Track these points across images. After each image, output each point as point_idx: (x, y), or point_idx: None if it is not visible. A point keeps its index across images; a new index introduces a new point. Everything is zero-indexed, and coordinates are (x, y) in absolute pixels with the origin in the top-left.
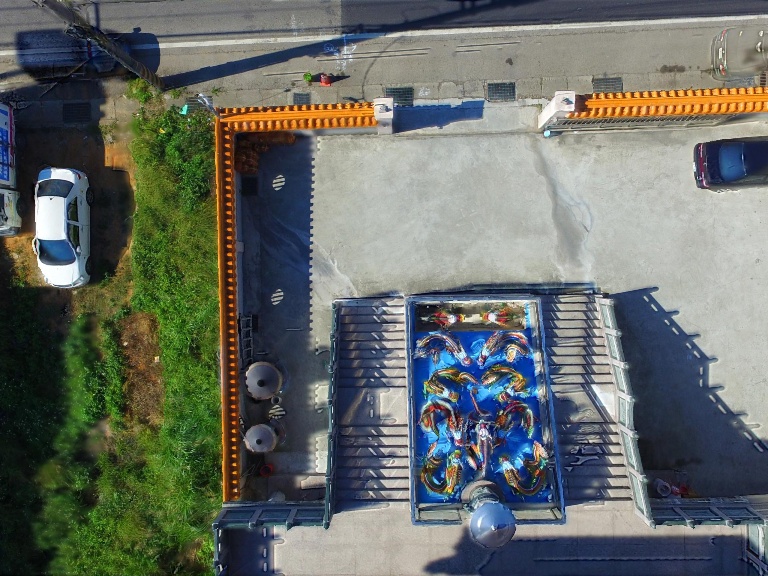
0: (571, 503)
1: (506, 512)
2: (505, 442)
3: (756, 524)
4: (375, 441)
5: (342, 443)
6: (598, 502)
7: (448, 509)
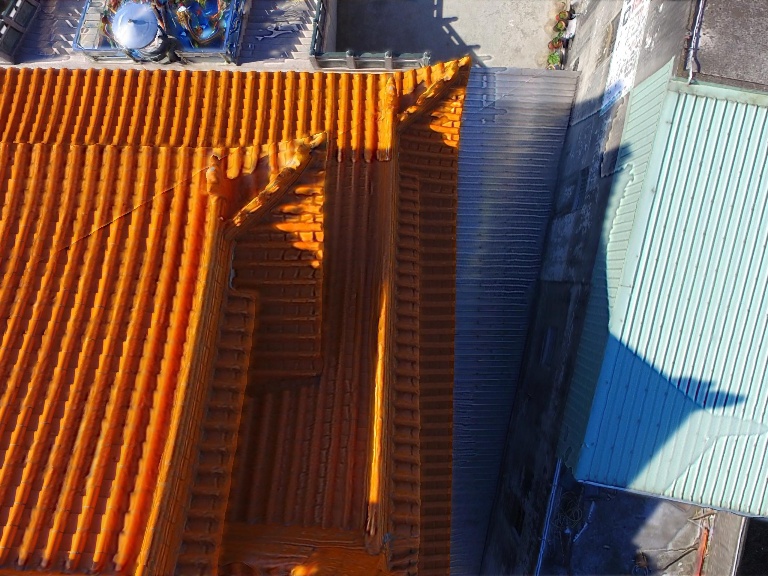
0: (251, 60)
1: (148, 12)
2: (200, 14)
3: (420, 63)
4: (75, 17)
5: (42, 18)
6: (278, 59)
7: (126, 59)
